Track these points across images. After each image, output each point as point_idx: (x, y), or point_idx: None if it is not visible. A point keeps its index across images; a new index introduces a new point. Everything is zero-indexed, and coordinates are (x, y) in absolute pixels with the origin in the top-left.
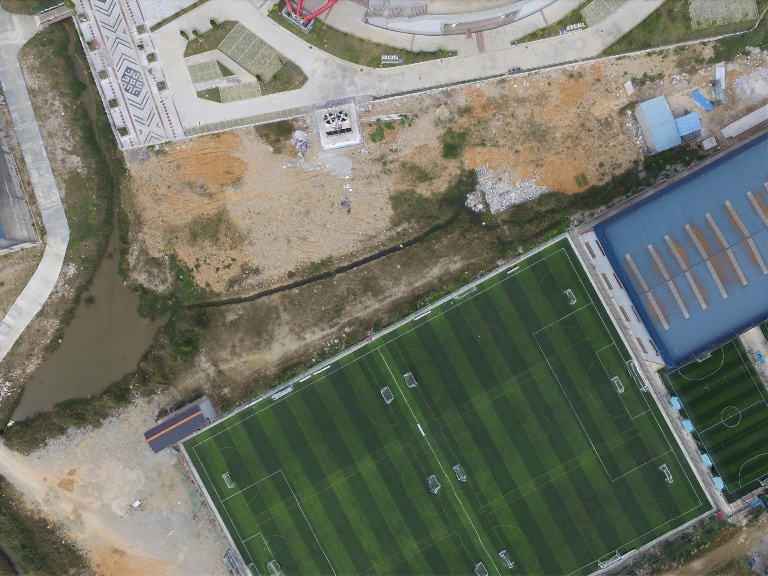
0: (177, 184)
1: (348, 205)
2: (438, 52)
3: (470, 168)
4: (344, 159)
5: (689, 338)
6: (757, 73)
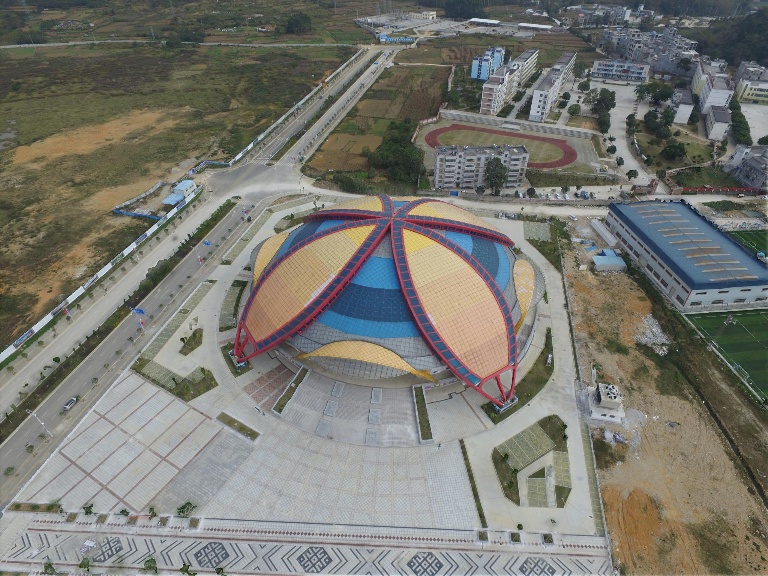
0: (662, 567)
1: (673, 423)
2: (549, 334)
3: (634, 345)
4: (629, 413)
5: (761, 271)
6: (578, 230)
